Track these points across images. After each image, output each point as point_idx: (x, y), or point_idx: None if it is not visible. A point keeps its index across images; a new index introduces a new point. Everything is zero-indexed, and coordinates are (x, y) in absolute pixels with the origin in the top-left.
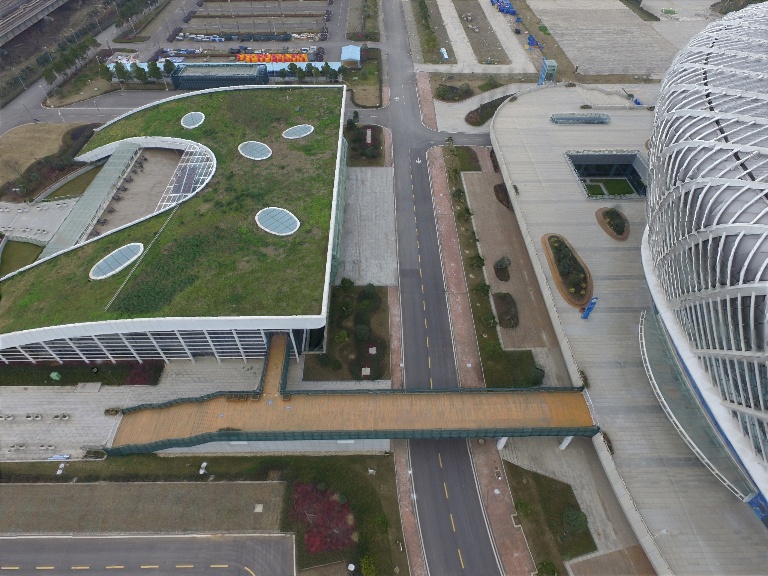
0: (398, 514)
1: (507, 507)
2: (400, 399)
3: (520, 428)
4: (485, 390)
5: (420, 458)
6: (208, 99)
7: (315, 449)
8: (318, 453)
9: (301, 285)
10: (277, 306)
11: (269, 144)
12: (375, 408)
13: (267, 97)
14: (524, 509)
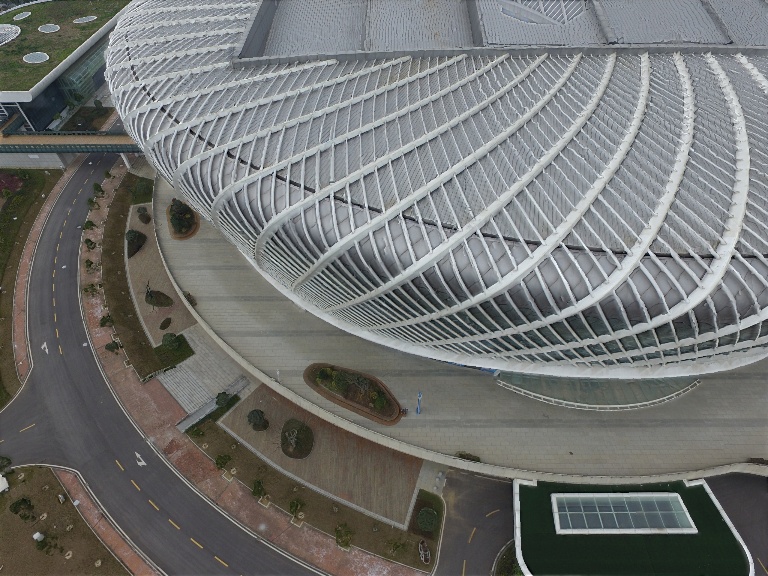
0: (52, 188)
1: (114, 186)
2: (70, 137)
3: (124, 144)
4: (118, 132)
5: (81, 171)
6: (41, 5)
7: (21, 165)
8: (24, 168)
9: (28, 82)
10: (8, 89)
11: (61, 26)
12: (53, 140)
13: (80, 3)
14: (104, 172)
